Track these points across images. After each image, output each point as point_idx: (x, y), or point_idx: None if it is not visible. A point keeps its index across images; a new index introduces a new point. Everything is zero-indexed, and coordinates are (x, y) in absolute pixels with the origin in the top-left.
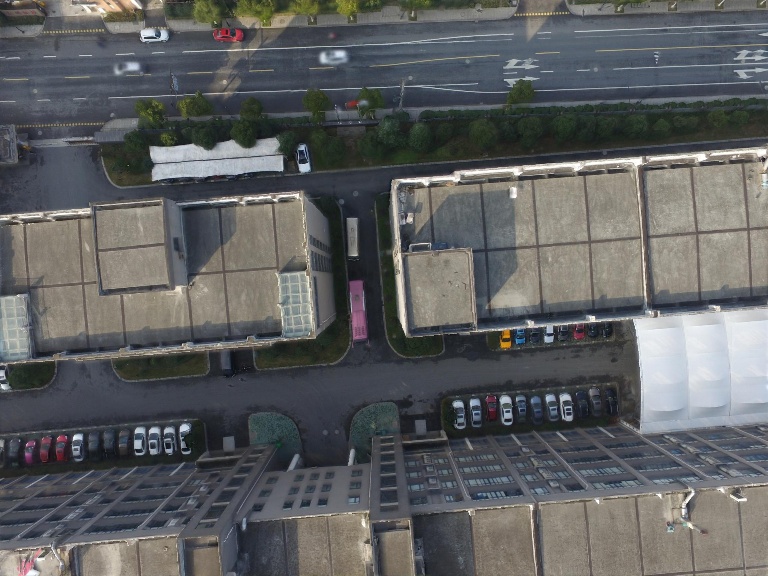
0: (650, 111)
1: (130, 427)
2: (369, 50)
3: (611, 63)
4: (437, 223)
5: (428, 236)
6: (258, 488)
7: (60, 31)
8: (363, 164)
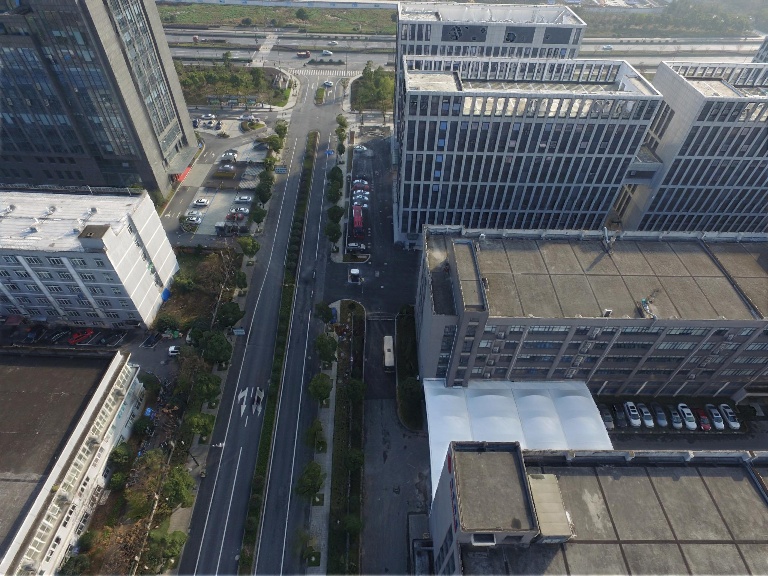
0: None
1: None
2: None
3: None
4: None
5: None
6: None
7: None
8: None
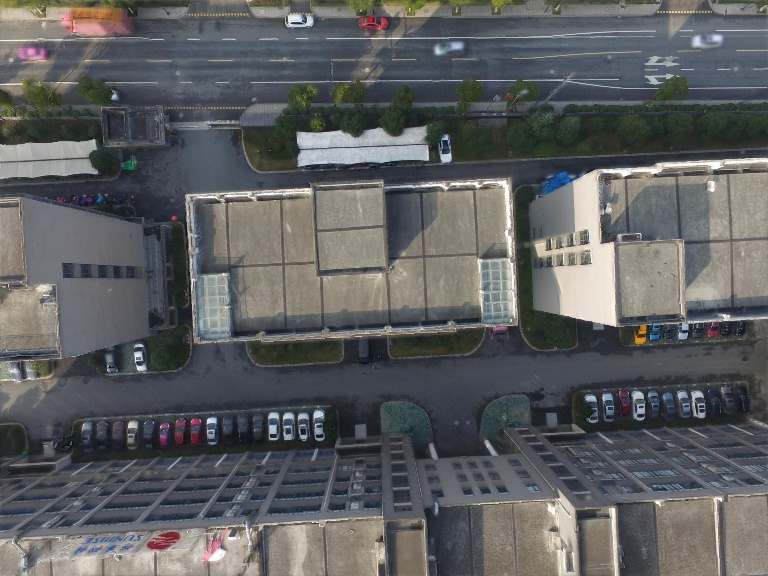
0: None
1: (263, 412)
2: (512, 42)
3: (751, 63)
4: (632, 214)
5: (623, 227)
6: (423, 475)
7: (204, 14)
8: (503, 156)
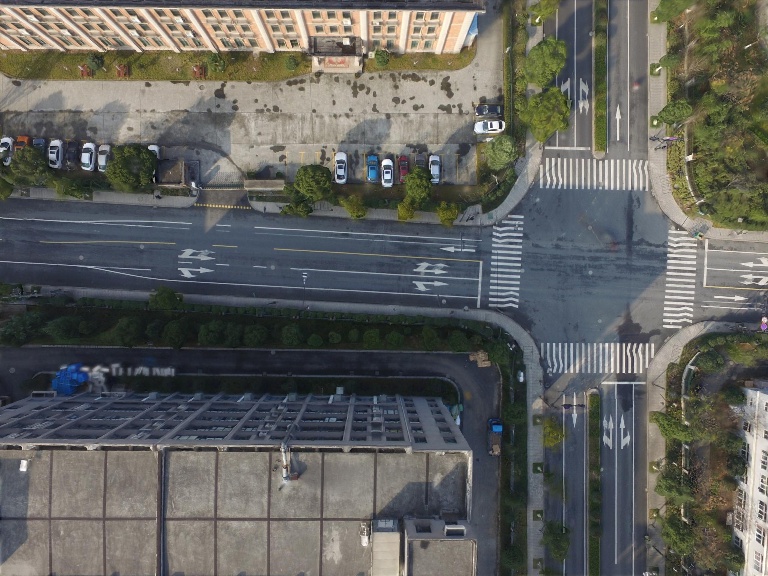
0: (316, 318)
1: None
2: (41, 225)
3: (289, 262)
4: None
5: None
6: None
7: None
8: None
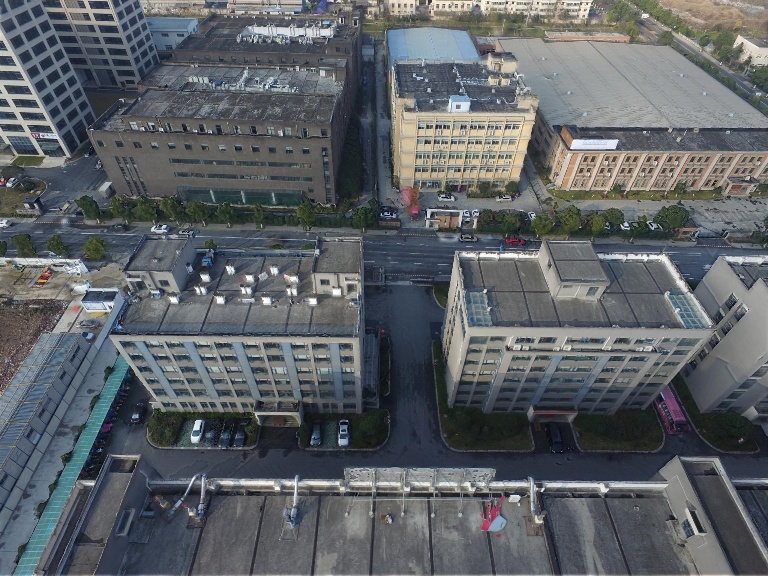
0: None
1: None
2: None
3: None
4: None
5: None
6: None
7: (408, 234)
8: None
